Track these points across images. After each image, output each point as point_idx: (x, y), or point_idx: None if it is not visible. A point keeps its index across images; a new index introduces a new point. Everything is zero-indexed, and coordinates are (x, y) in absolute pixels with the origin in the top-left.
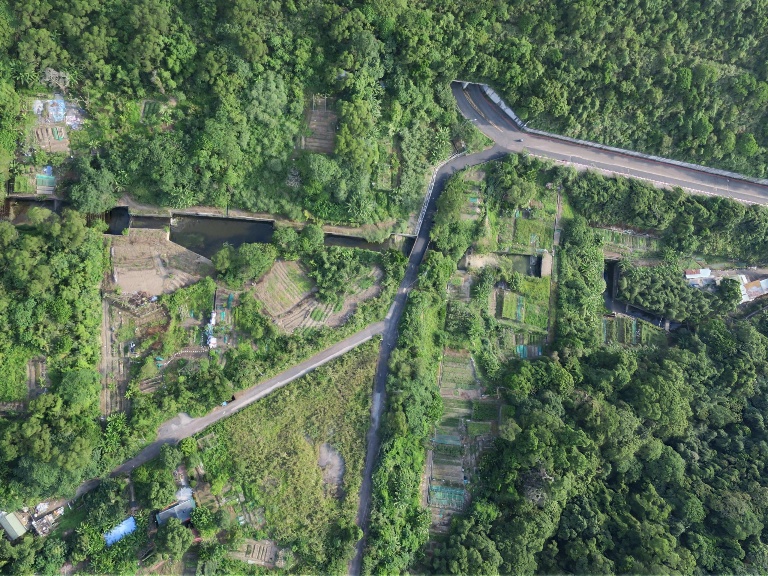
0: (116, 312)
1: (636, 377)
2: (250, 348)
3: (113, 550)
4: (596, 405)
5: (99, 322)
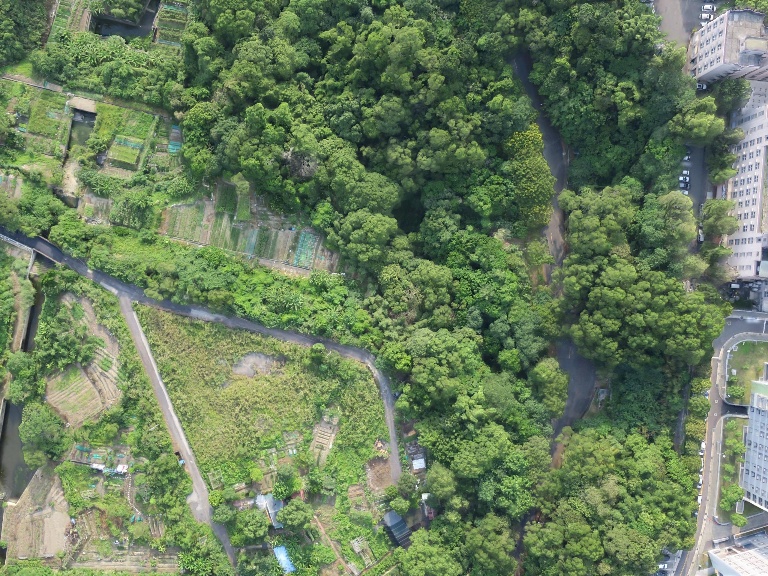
0: (83, 557)
1: (212, 27)
2: (132, 433)
3: (298, 567)
4: (229, 84)
5: (91, 573)
